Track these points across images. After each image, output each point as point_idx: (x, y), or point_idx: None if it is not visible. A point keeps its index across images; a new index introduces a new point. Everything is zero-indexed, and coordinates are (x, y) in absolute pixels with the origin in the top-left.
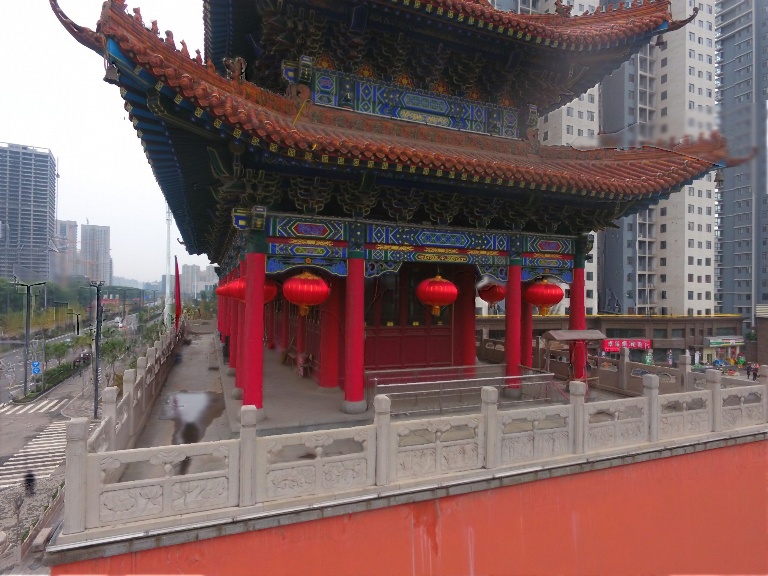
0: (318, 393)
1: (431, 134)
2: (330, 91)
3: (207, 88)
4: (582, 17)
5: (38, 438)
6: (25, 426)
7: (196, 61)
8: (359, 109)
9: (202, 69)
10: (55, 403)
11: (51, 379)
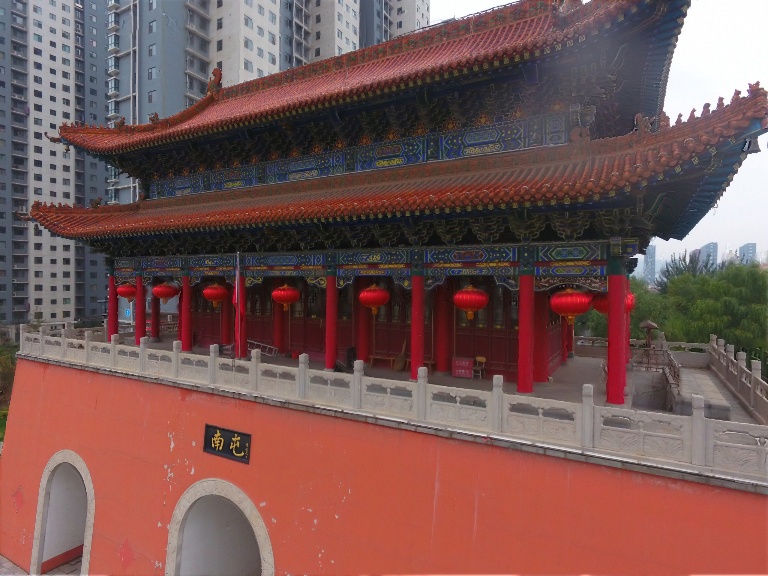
0: (545, 388)
1: None
2: None
3: None
4: None
5: None
6: None
7: None
8: None
9: None
10: None
11: None
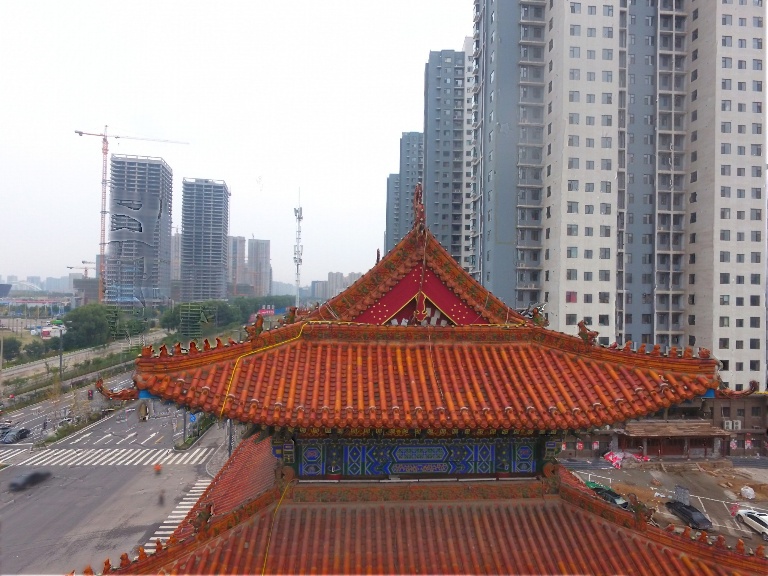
0: None
1: (424, 492)
2: (317, 460)
3: (165, 573)
4: (608, 351)
5: (184, 501)
6: (177, 483)
7: (154, 554)
8: (347, 471)
9: (161, 556)
10: (204, 453)
11: (205, 422)
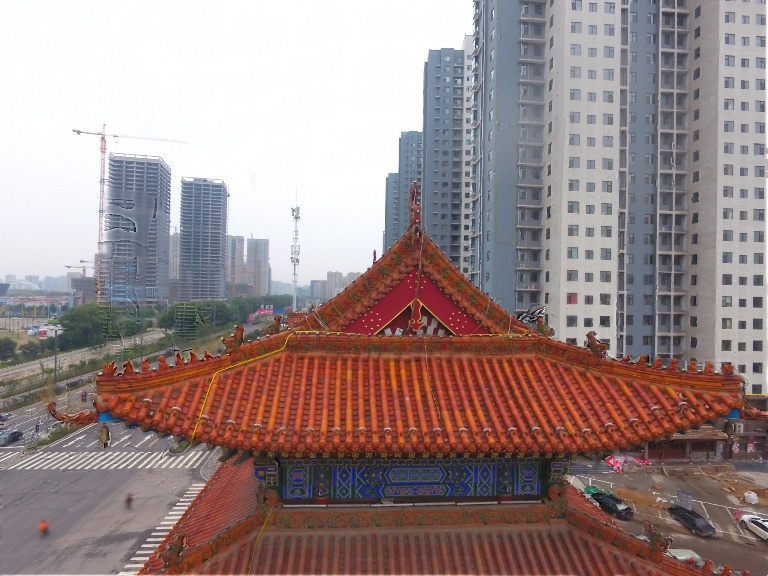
0: None
1: (419, 517)
2: (303, 483)
3: None
4: (620, 365)
5: (177, 506)
6: (171, 488)
7: None
8: (336, 494)
9: None
10: (199, 456)
11: None
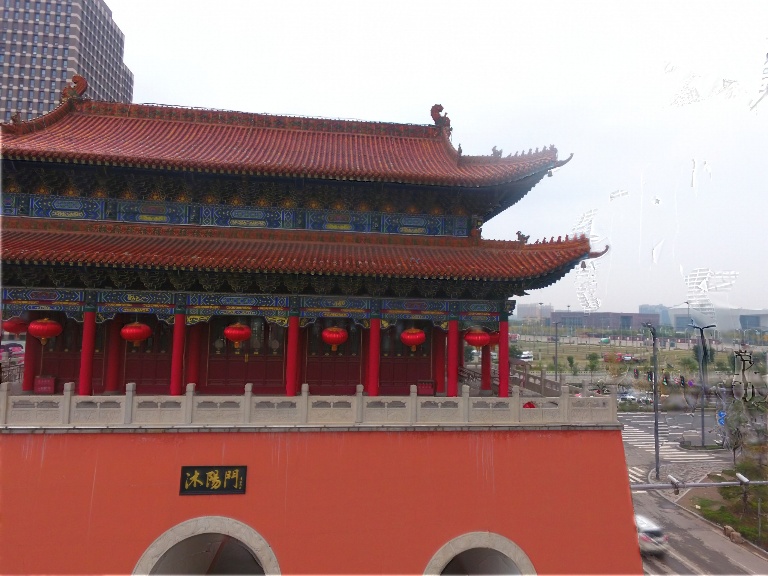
0: None
1: None
2: None
3: None
4: None
5: None
6: None
7: None
8: None
9: None
10: (700, 458)
11: None
